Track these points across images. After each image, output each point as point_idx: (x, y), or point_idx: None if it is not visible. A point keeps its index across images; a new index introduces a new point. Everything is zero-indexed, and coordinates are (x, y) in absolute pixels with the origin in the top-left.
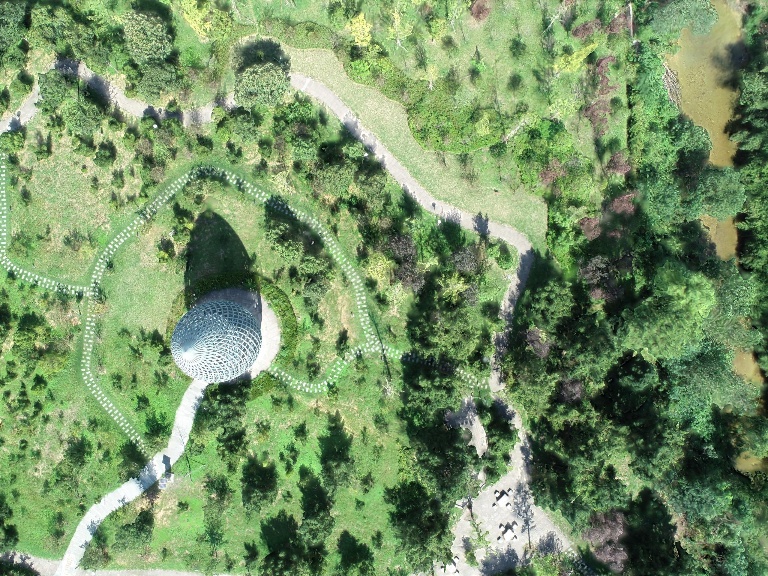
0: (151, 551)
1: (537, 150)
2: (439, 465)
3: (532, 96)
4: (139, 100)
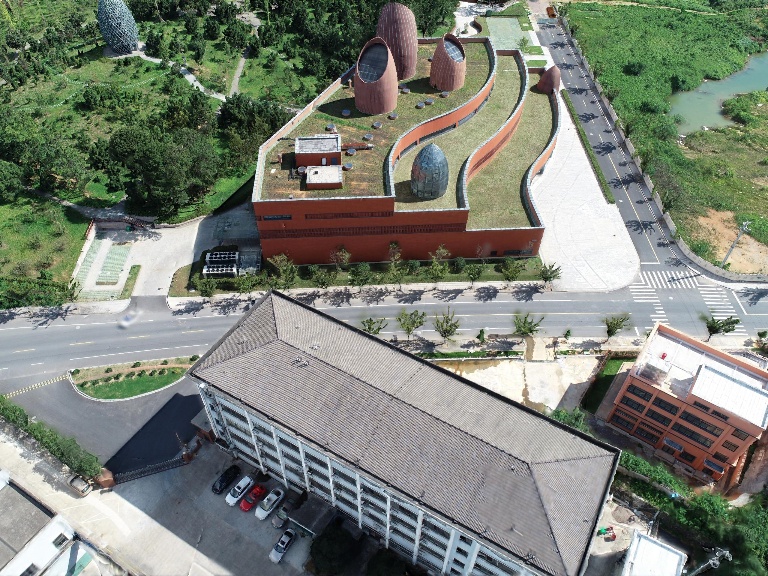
0: None
1: None
2: None
3: None
4: (0, 81)
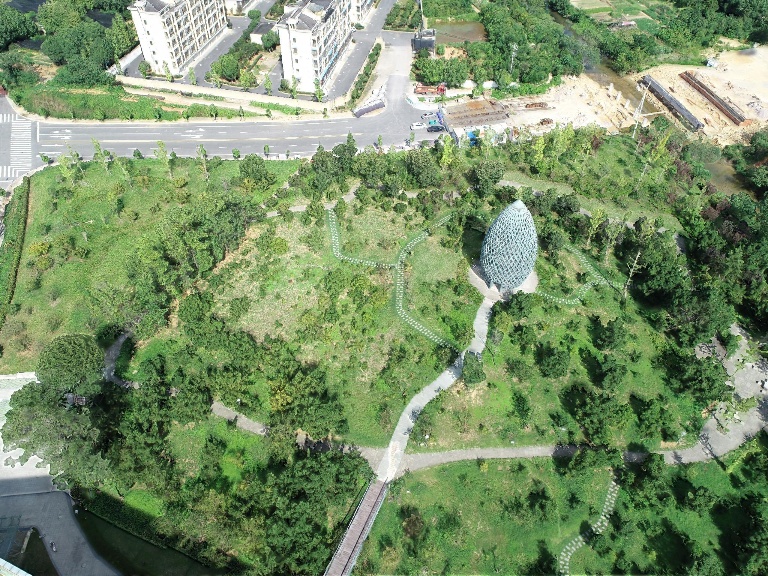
0: (469, 428)
1: (658, 189)
2: (693, 293)
3: None
4: (413, 192)
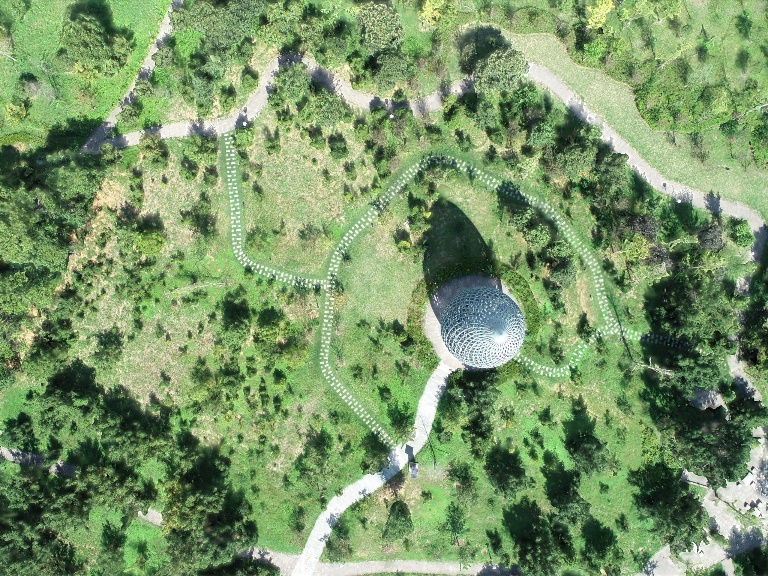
0: (392, 542)
1: None
2: (715, 443)
3: (760, 72)
4: (365, 91)
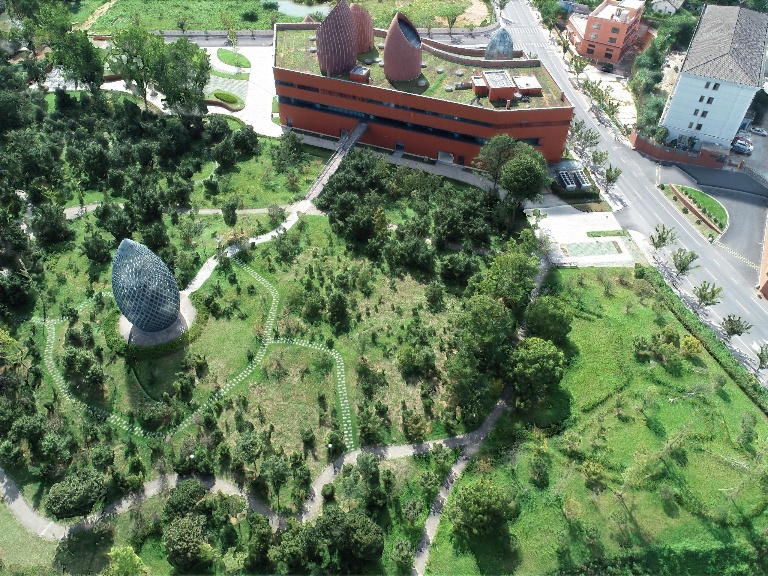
0: (242, 219)
1: None
2: (6, 235)
3: None
4: None
